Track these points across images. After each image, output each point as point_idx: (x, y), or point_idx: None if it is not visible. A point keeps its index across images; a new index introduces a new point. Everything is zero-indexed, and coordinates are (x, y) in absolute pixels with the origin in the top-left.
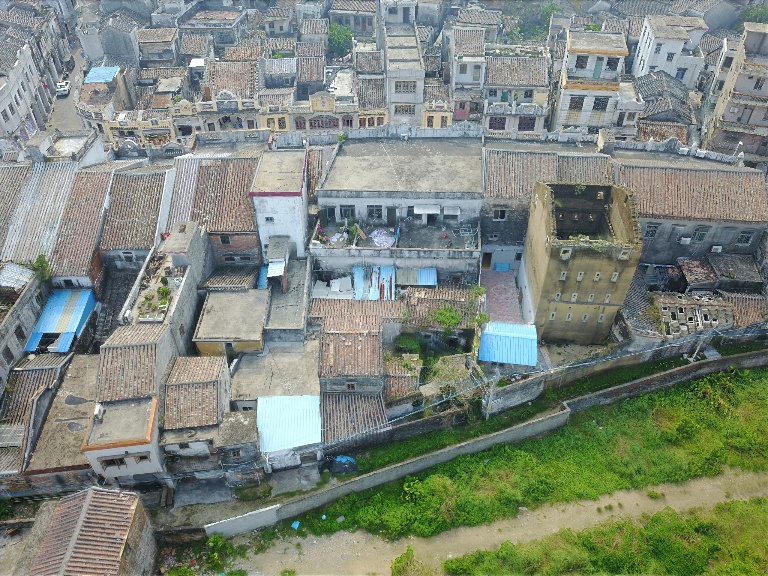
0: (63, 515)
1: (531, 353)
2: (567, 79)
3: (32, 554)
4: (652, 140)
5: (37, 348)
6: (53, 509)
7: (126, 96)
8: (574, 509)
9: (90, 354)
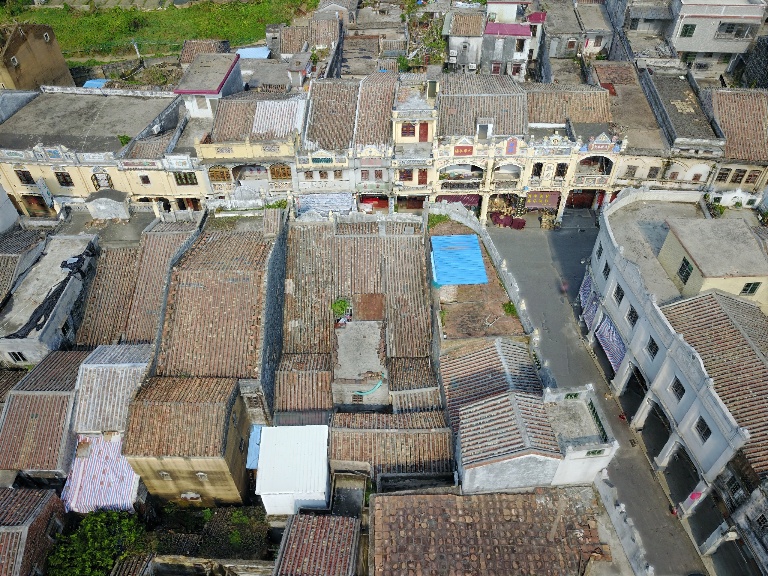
0: (344, 3)
1: (98, 80)
2: None
3: (354, 1)
4: None
5: (399, 71)
6: (351, 8)
7: None
8: None
9: (367, 74)
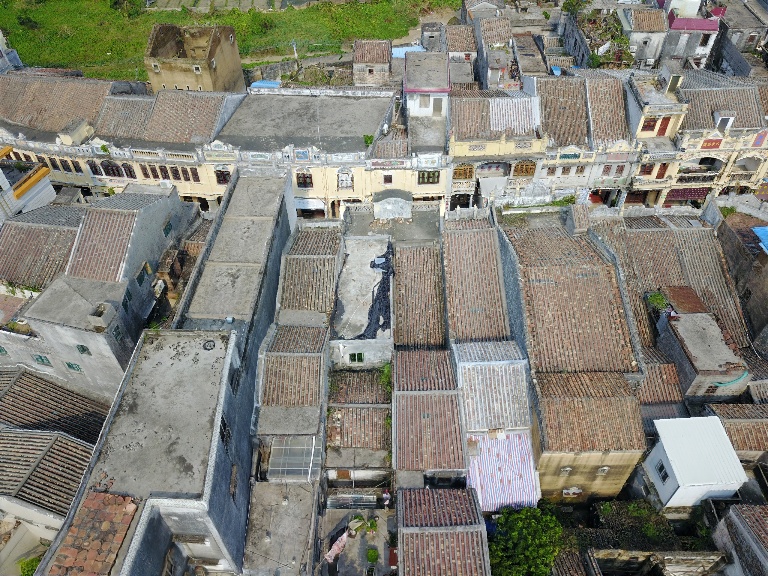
0: None
1: None
2: (38, 164)
3: None
4: (22, 135)
5: (572, 67)
6: (500, 6)
7: (764, 313)
8: (274, 60)
9: (538, 71)
